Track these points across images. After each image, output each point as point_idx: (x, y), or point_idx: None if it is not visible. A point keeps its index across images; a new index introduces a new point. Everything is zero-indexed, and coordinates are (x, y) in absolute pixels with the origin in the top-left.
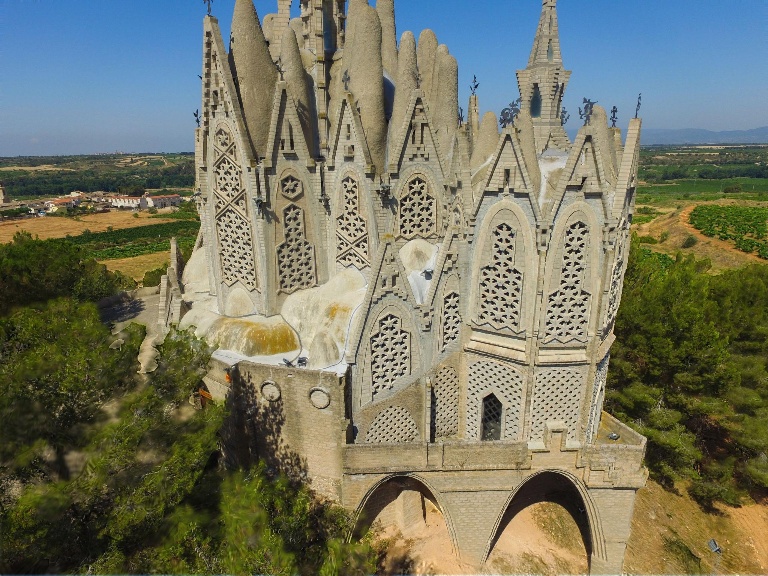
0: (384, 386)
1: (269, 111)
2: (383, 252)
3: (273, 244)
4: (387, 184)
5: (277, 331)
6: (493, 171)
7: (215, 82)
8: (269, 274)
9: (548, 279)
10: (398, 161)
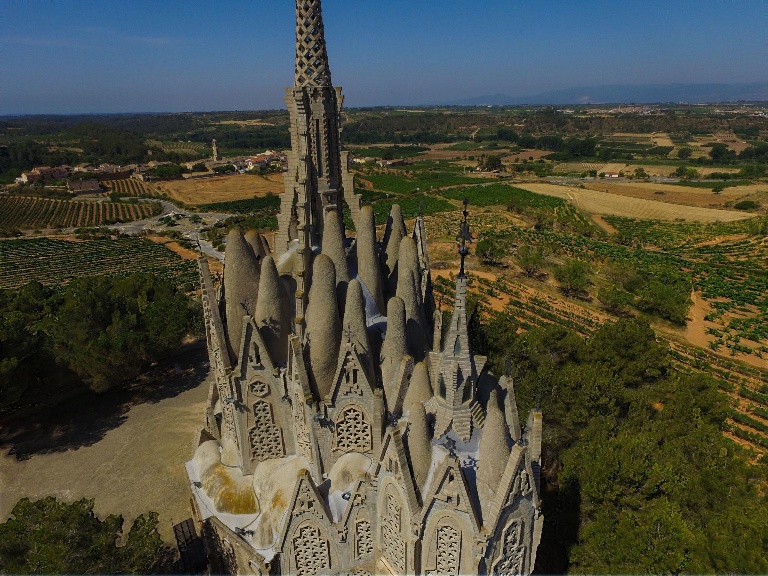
0: (308, 571)
1: None
2: (299, 484)
3: (246, 427)
4: (323, 412)
5: (242, 496)
6: (385, 451)
7: (207, 303)
8: (244, 447)
9: (425, 557)
10: (332, 397)
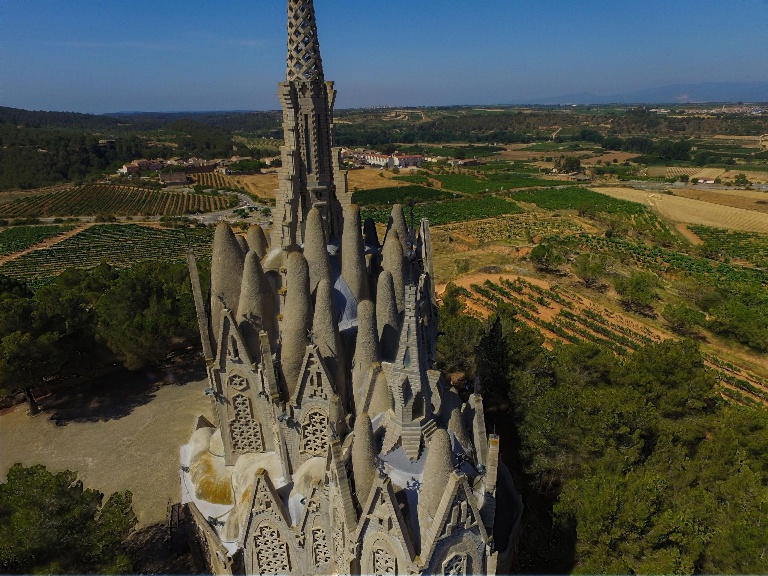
0: (271, 571)
1: (235, 314)
2: (256, 483)
3: (227, 419)
4: (289, 413)
5: (220, 486)
6: None
7: None
8: (225, 438)
9: None
10: (296, 398)
